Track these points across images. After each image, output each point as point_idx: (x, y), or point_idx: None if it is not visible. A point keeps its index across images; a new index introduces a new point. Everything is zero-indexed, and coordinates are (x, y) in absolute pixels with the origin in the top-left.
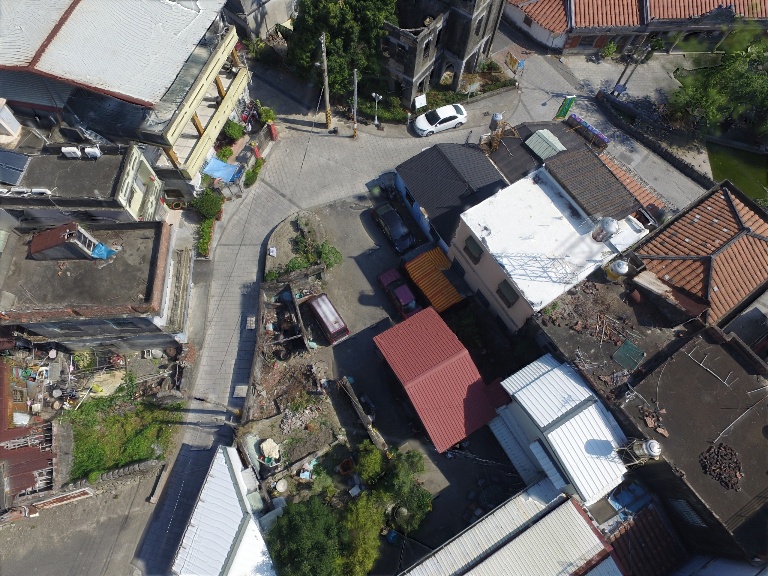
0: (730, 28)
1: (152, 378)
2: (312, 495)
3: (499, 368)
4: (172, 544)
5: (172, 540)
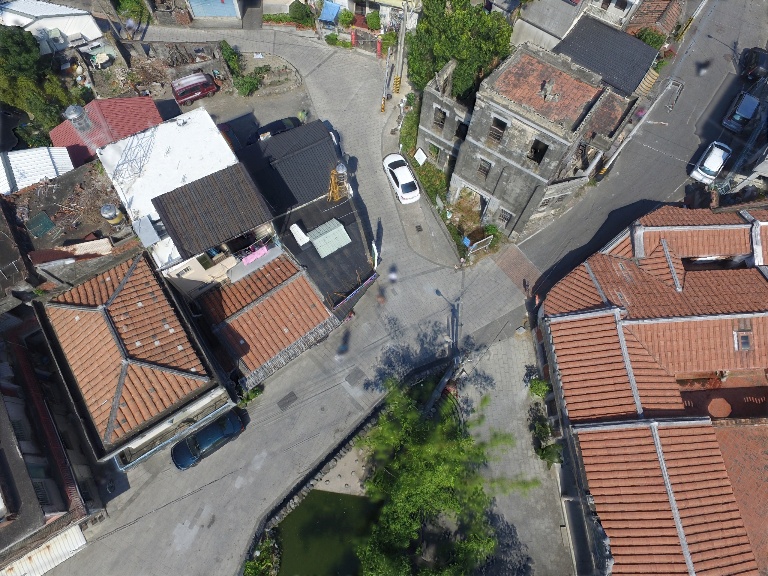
0: None
1: (171, 3)
2: None
3: None
4: None
5: None
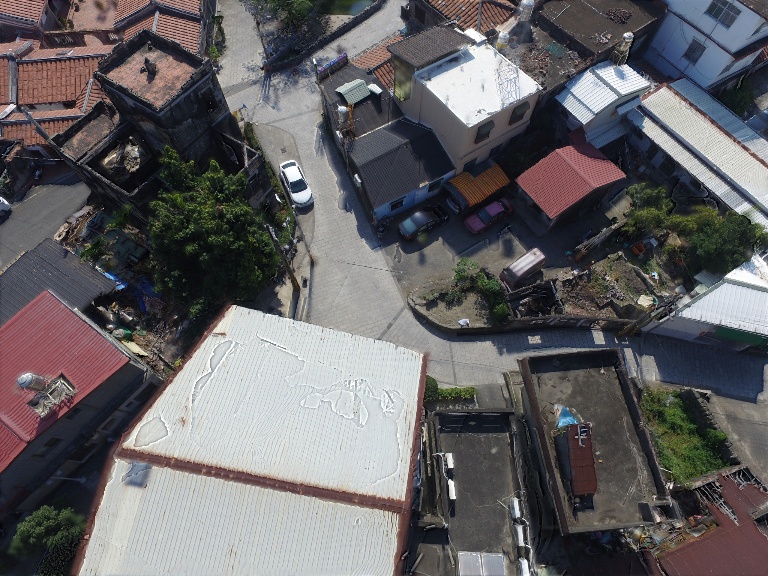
0: None
1: None
2: (691, 244)
3: (537, 154)
4: (732, 373)
5: (729, 373)
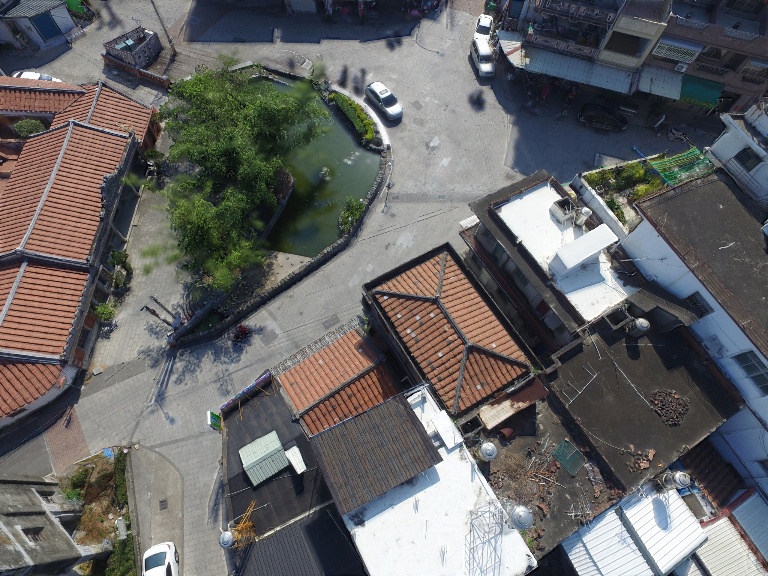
0: (125, 179)
1: None
2: None
3: None
4: None
5: None
